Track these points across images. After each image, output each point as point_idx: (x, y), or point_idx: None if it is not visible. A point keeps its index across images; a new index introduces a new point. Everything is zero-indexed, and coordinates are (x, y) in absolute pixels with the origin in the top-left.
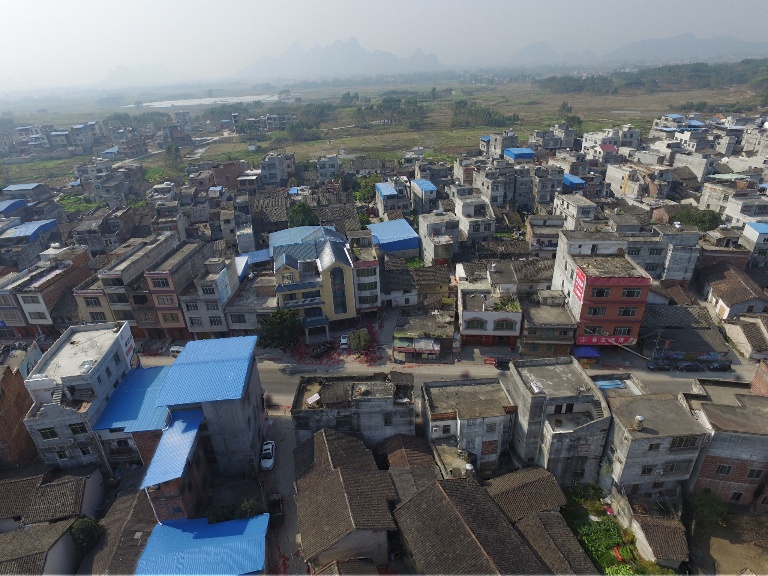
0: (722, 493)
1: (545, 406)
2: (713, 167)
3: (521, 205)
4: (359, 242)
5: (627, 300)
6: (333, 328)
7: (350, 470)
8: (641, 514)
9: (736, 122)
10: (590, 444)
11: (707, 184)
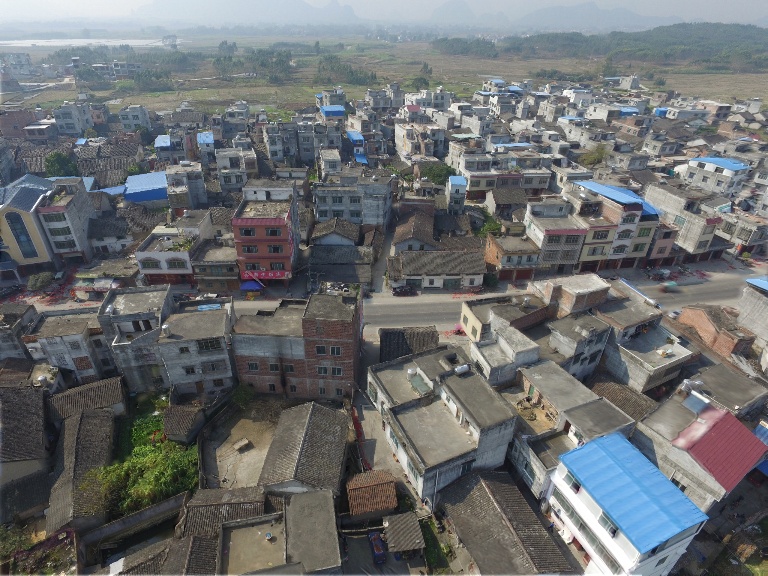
0: (261, 386)
1: (112, 323)
2: (489, 129)
3: (307, 160)
4: (66, 189)
5: (272, 238)
6: (31, 273)
7: None
8: (176, 404)
9: (551, 89)
10: (154, 353)
11: (451, 142)
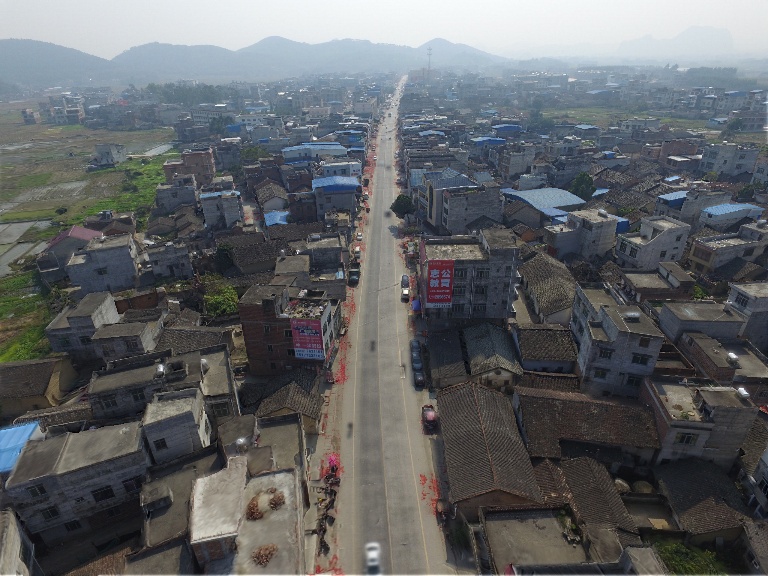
0: None
1: None
2: None
3: None
4: None
5: None
6: (433, 229)
7: (296, 226)
8: None
9: None
10: None
11: None
